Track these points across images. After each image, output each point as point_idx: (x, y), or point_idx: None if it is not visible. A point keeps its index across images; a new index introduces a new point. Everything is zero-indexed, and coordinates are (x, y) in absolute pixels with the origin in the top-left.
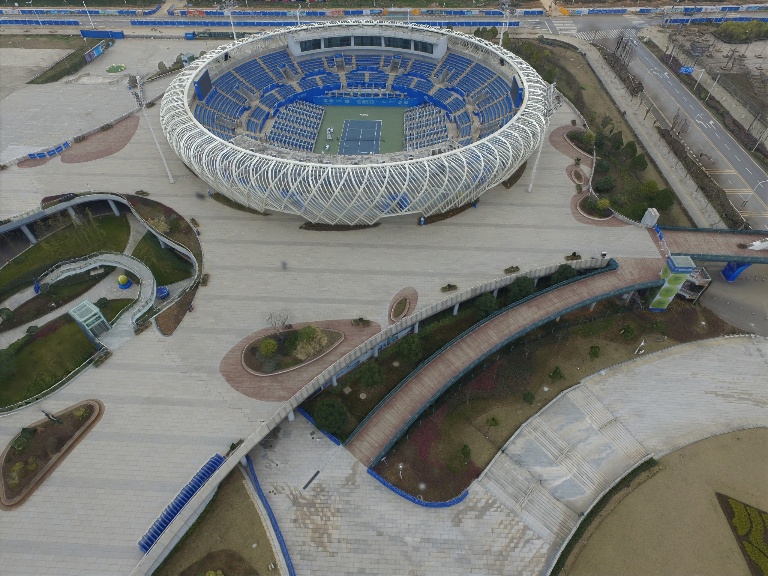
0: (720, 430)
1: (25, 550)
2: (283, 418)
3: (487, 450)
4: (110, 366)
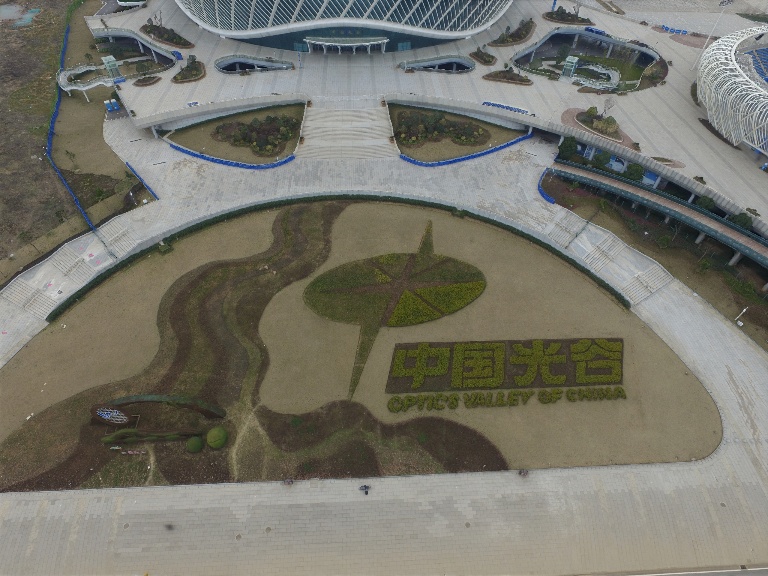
0: (688, 363)
1: (472, 85)
2: (557, 132)
3: (585, 216)
4: (551, 82)
